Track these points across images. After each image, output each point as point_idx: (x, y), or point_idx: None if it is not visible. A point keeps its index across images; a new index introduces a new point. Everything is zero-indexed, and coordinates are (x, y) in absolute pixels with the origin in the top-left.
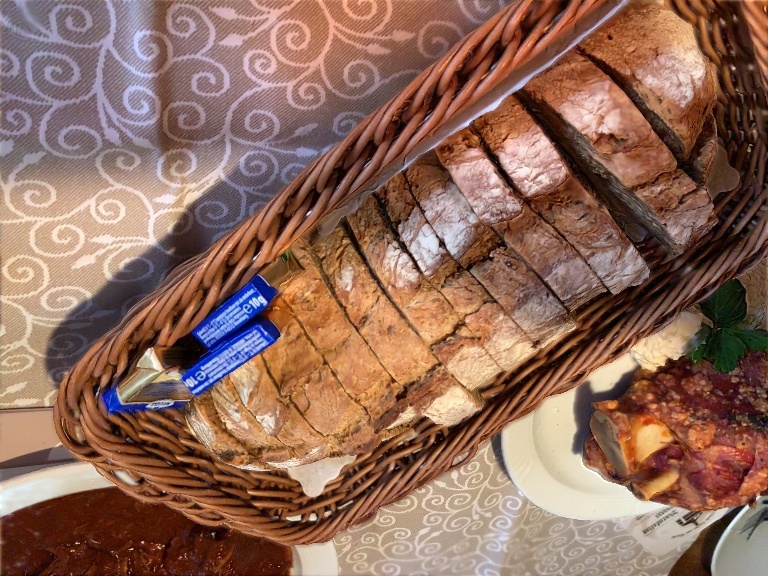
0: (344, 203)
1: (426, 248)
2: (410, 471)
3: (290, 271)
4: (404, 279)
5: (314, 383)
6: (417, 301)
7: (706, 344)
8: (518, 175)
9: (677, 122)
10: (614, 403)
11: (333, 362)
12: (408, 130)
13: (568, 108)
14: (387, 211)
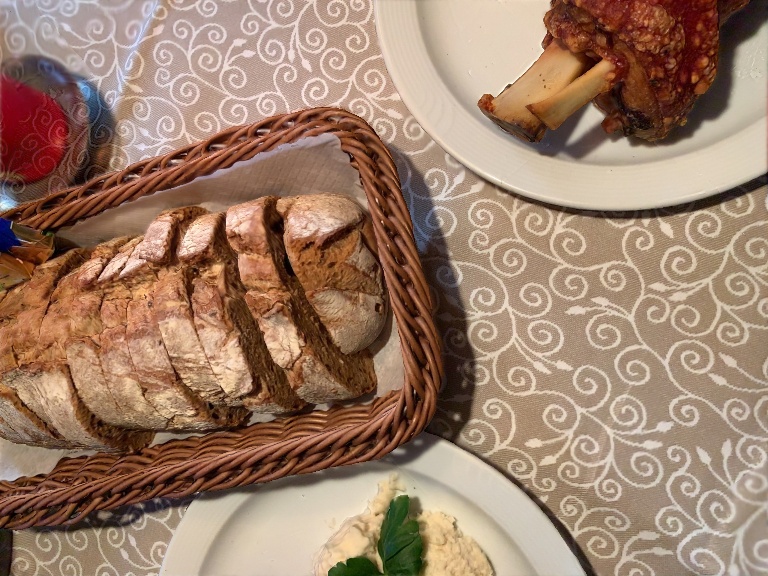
0: (89, 215)
1: (113, 267)
2: (39, 493)
3: (40, 241)
4: (85, 276)
5: (6, 328)
6: (85, 298)
7: (349, 568)
8: (184, 244)
9: (291, 251)
10: None
11: (21, 315)
12: (133, 181)
13: (231, 214)
14: None
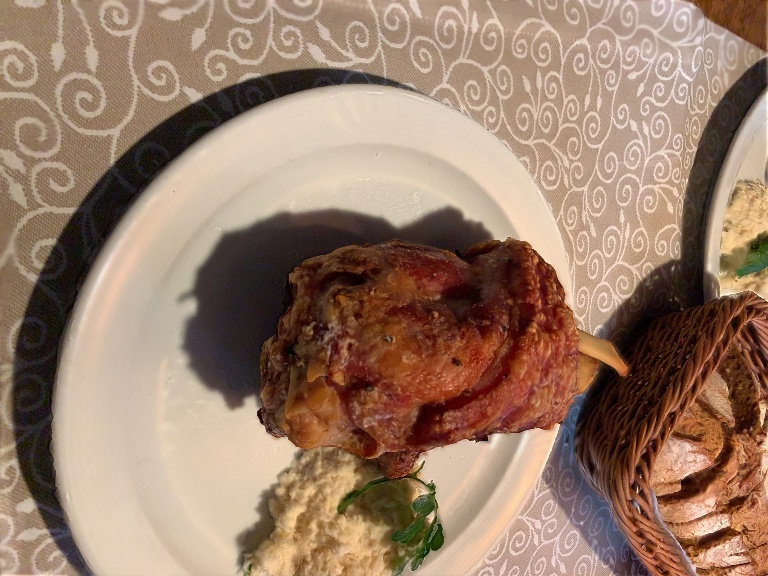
0: None
1: None
2: None
3: None
4: (750, 571)
5: None
6: (760, 559)
7: None
8: None
9: None
10: None
11: None
12: None
13: None
14: (704, 569)
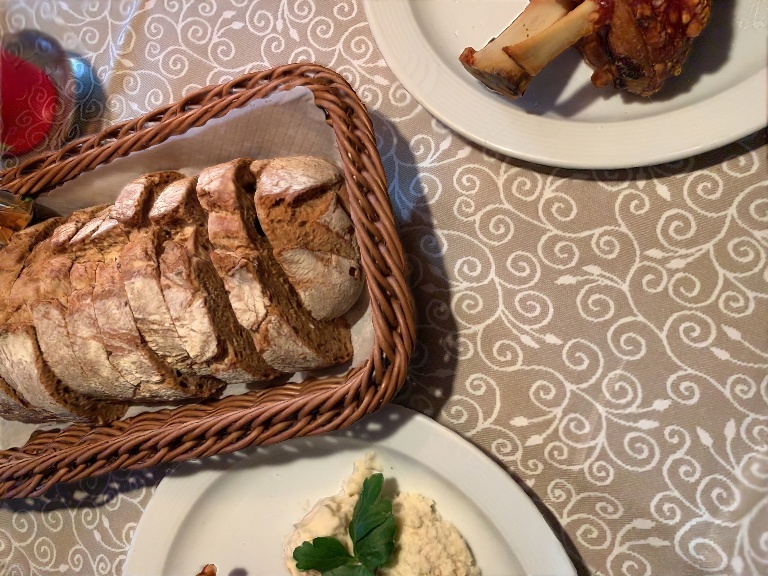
0: (67, 179)
1: (86, 230)
2: (6, 463)
3: (18, 205)
4: (58, 239)
5: None
6: (56, 260)
7: (315, 548)
8: None
9: (260, 208)
10: (211, 567)
11: None
12: (109, 143)
13: None
14: (99, 211)
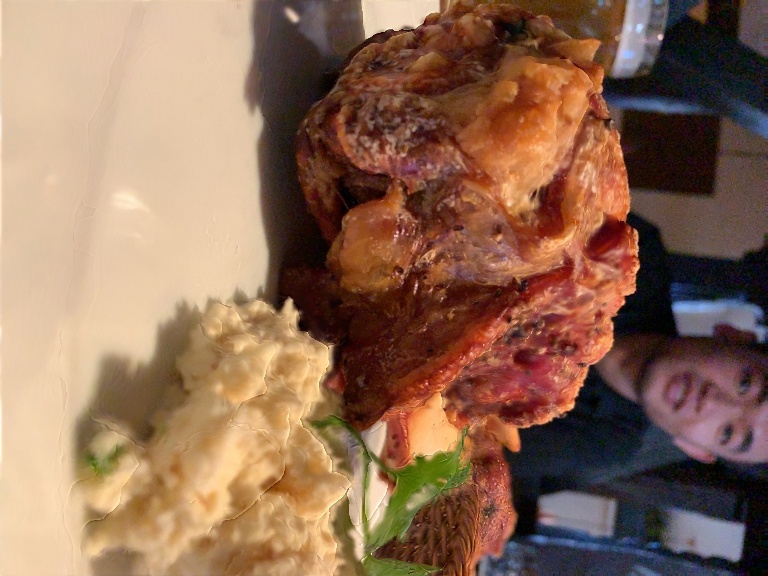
0: None
1: None
2: None
3: None
4: None
5: None
6: None
7: None
8: None
9: None
10: None
11: None
12: None
13: None
14: None
